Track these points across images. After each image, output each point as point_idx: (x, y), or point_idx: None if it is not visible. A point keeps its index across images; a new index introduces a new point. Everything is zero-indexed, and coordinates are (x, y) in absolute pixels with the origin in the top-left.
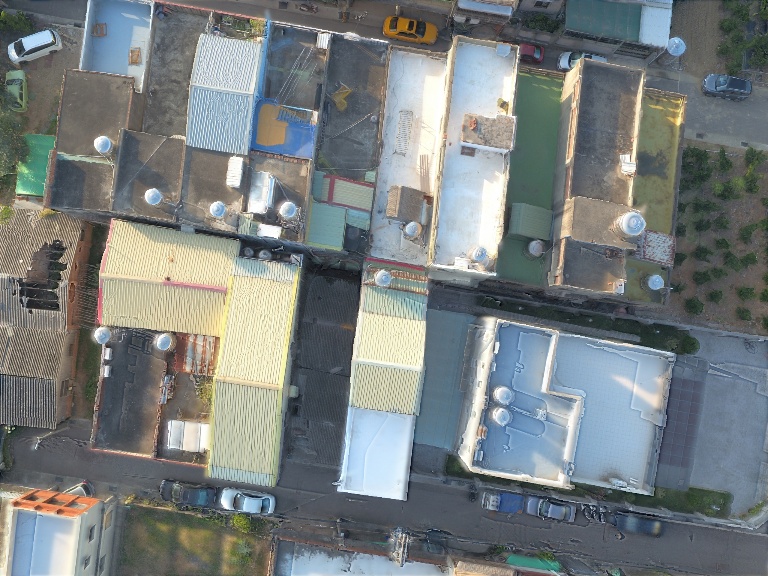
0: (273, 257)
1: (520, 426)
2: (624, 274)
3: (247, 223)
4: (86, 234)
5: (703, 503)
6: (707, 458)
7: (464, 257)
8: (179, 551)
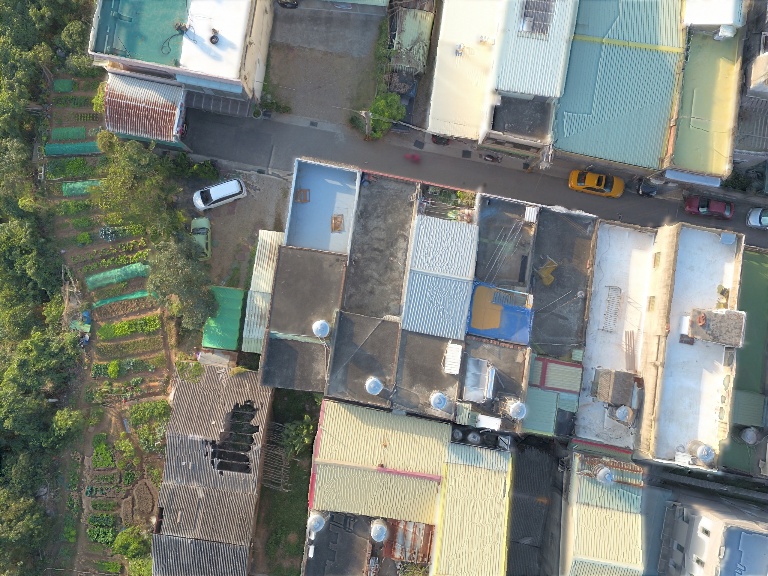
0: (481, 439)
1: None
2: None
3: (465, 413)
4: (273, 391)
5: None
6: None
7: (684, 452)
8: None
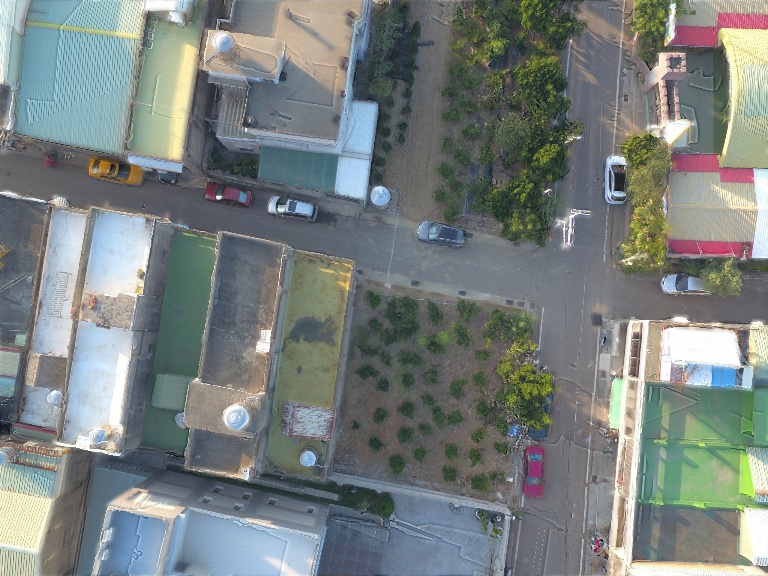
0: None
1: None
2: (252, 458)
3: None
4: None
5: None
6: None
7: (88, 436)
8: None
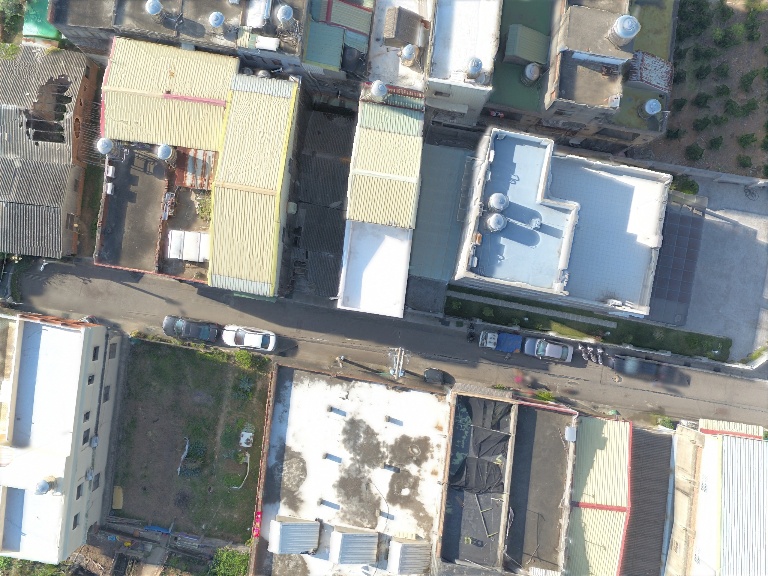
0: (272, 77)
1: (515, 237)
2: (620, 88)
3: (246, 35)
4: (91, 73)
5: (701, 346)
6: (706, 303)
7: (460, 71)
8: (181, 386)
